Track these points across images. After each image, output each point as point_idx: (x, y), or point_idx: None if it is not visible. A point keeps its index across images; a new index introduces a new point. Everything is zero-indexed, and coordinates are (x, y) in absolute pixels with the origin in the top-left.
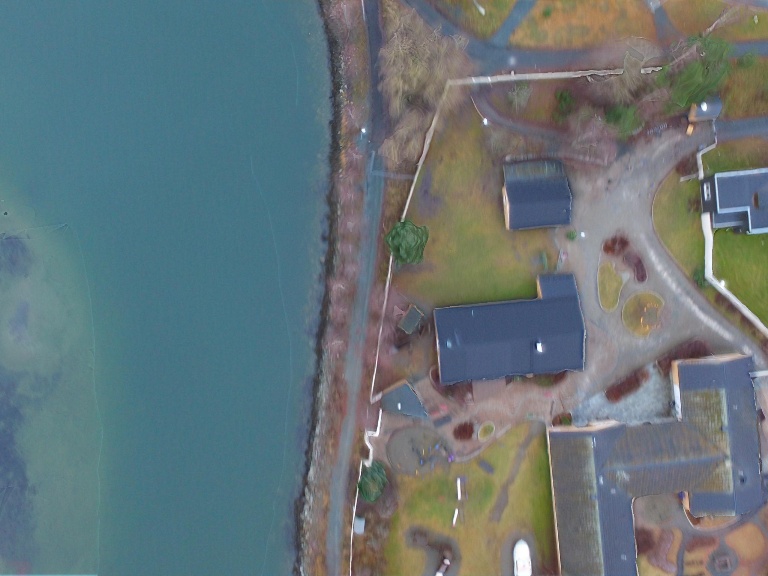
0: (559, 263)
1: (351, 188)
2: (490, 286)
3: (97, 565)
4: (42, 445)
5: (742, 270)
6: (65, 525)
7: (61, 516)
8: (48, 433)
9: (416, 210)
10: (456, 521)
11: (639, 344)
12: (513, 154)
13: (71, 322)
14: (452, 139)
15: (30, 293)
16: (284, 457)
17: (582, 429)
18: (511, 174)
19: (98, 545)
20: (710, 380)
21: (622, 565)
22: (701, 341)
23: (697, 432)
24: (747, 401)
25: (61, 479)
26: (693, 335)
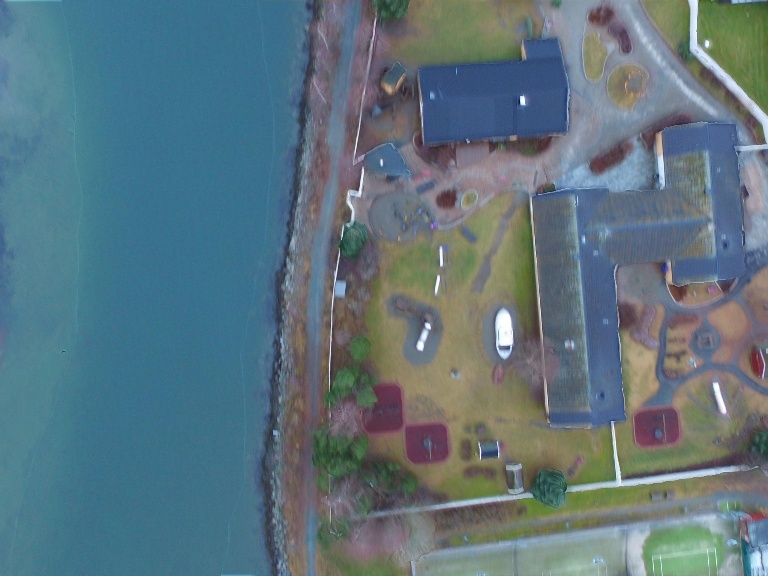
0: (544, 31)
1: None
2: (475, 53)
3: (75, 334)
4: (21, 209)
5: (727, 42)
6: (43, 292)
7: (39, 282)
8: (27, 196)
9: None
10: (438, 290)
11: (623, 117)
12: None
13: (52, 84)
14: None
15: (11, 53)
16: (266, 230)
17: None
18: None
19: (76, 314)
20: (694, 144)
21: (604, 330)
22: (685, 115)
23: (680, 198)
24: (730, 168)
25: (39, 243)
26: (677, 109)
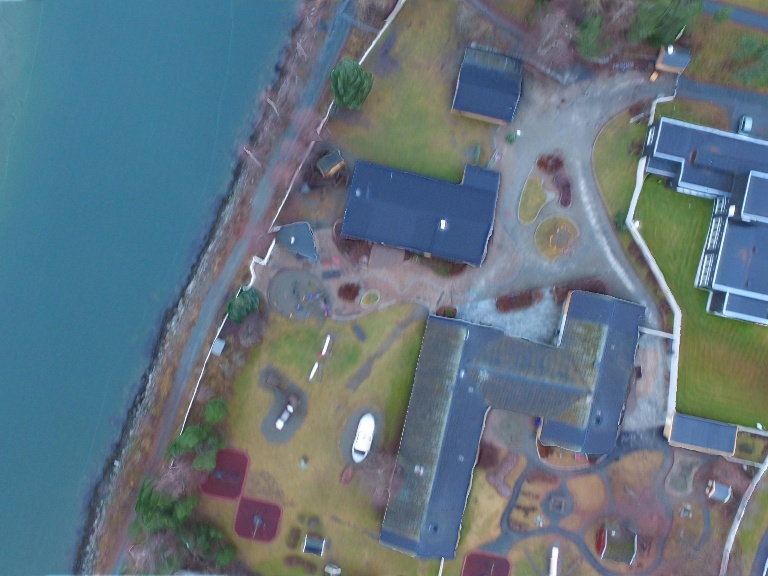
0: (491, 162)
1: (317, 26)
2: (419, 162)
3: None
4: None
5: (662, 226)
6: None
7: None
8: None
9: (371, 66)
10: (313, 376)
11: (543, 265)
12: (479, 41)
13: (10, 66)
14: (426, 7)
15: None
16: (171, 266)
17: (460, 319)
18: (470, 57)
19: None
20: (597, 314)
21: (457, 466)
22: (603, 282)
23: (570, 361)
24: (627, 348)
25: None
26: (597, 274)
